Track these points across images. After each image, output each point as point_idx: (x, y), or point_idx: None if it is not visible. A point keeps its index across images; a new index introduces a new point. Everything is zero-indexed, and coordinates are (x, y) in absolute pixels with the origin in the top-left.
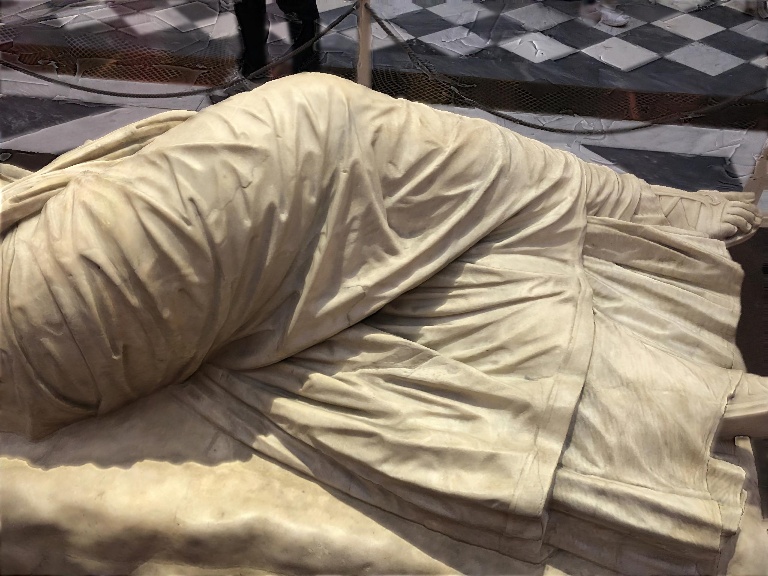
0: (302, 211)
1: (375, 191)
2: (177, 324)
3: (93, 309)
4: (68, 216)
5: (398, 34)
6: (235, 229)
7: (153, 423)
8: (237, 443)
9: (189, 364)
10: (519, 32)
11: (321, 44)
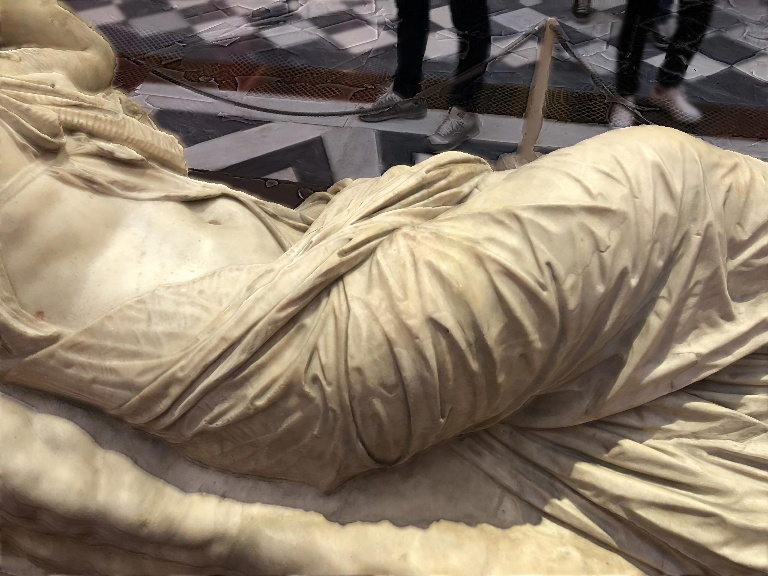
0: (647, 275)
1: (722, 254)
2: (505, 387)
3: (435, 373)
4: (411, 275)
5: (580, 55)
6: (587, 294)
7: (438, 478)
8: (523, 504)
9: (485, 422)
10: (662, 45)
11: (494, 65)
